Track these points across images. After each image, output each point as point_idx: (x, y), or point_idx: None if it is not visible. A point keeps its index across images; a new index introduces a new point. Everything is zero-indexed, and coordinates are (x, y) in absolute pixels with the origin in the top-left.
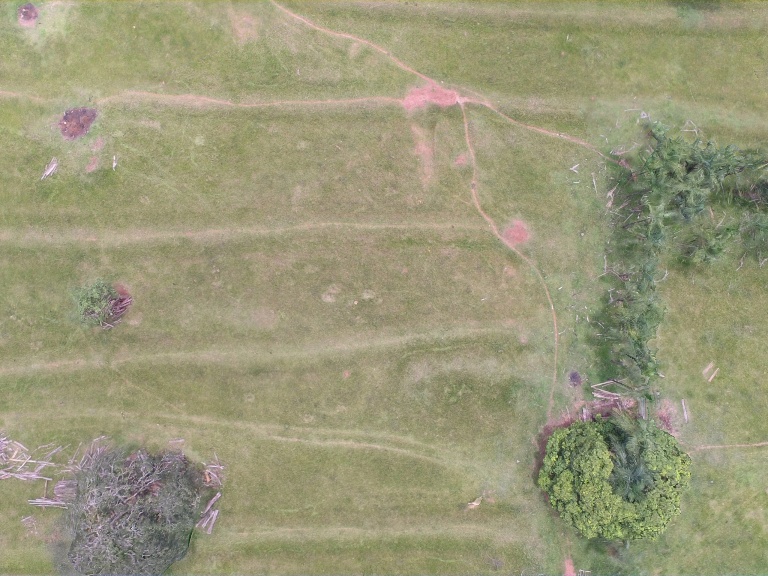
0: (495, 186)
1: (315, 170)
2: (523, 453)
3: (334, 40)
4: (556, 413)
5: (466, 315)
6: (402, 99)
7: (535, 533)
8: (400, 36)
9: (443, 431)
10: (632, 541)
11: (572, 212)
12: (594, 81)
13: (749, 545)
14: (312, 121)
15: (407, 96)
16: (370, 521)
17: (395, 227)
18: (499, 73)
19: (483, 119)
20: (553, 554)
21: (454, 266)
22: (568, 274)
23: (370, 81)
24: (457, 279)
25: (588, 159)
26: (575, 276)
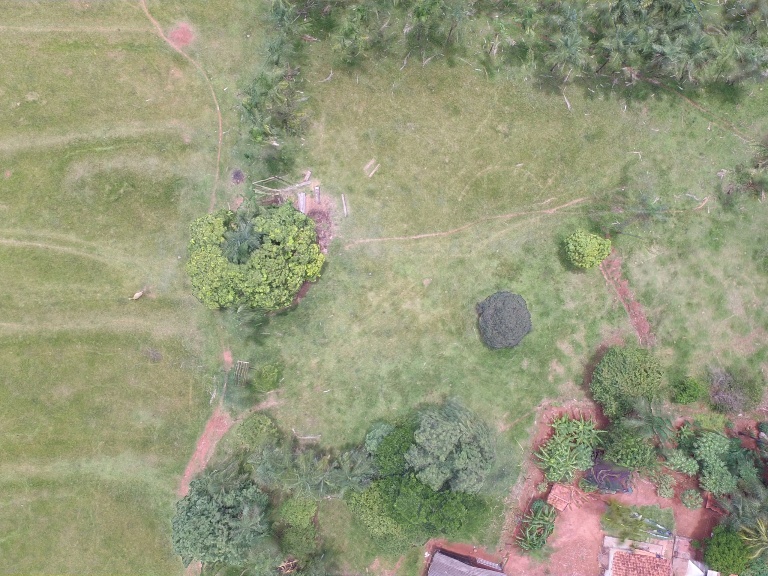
0: None
1: None
2: (184, 249)
3: None
4: (218, 210)
5: (131, 116)
6: None
7: (193, 326)
8: None
9: (104, 228)
10: (290, 332)
11: (239, 14)
12: None
13: (405, 334)
14: None
15: None
16: (29, 317)
17: (61, 30)
18: None
19: None
20: (212, 346)
21: (119, 68)
22: (232, 74)
23: None
24: (122, 81)
25: None
26: (240, 77)
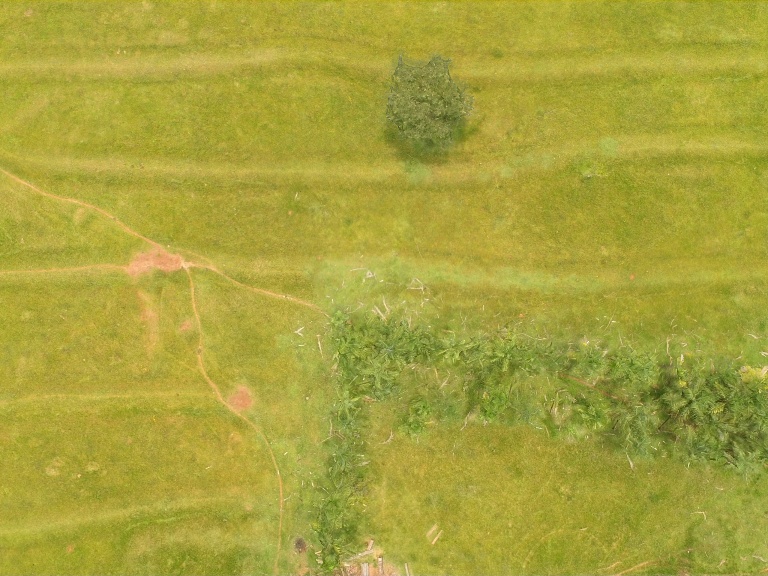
0: (220, 352)
1: (39, 341)
2: None
3: (60, 206)
4: None
5: (191, 484)
6: (126, 266)
7: None
8: (126, 200)
9: None
10: None
11: (297, 376)
12: (321, 240)
13: None
14: (37, 290)
15: (132, 262)
16: None
17: (120, 397)
18: (226, 235)
19: (209, 283)
20: None
21: (179, 435)
22: (292, 439)
23: (95, 248)
24: (182, 448)
25: (313, 321)
26: (300, 441)
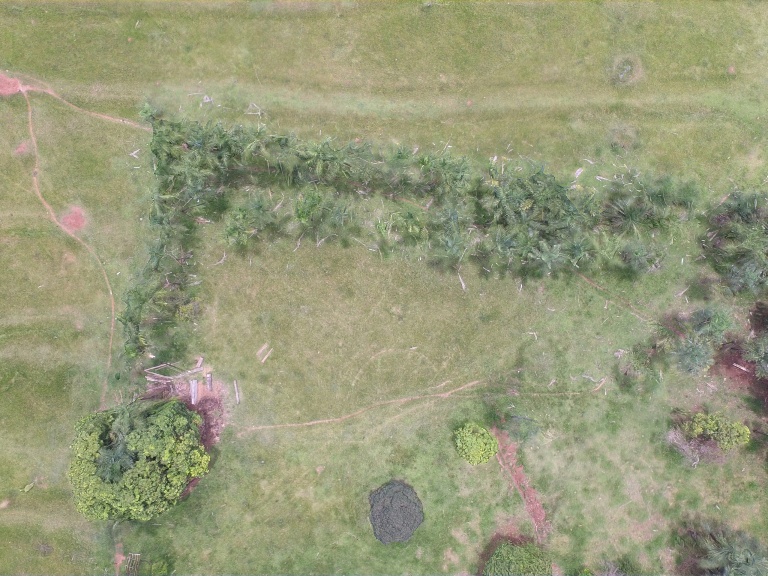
0: (55, 173)
1: None
2: None
3: None
4: (110, 398)
5: (23, 303)
6: None
7: (84, 518)
8: None
9: None
10: (182, 523)
11: (131, 197)
12: (160, 66)
13: (298, 523)
14: None
15: None
16: None
17: None
18: (65, 60)
19: (46, 107)
20: (103, 538)
21: (12, 254)
22: (125, 259)
23: None
24: (15, 267)
25: None
26: (133, 261)
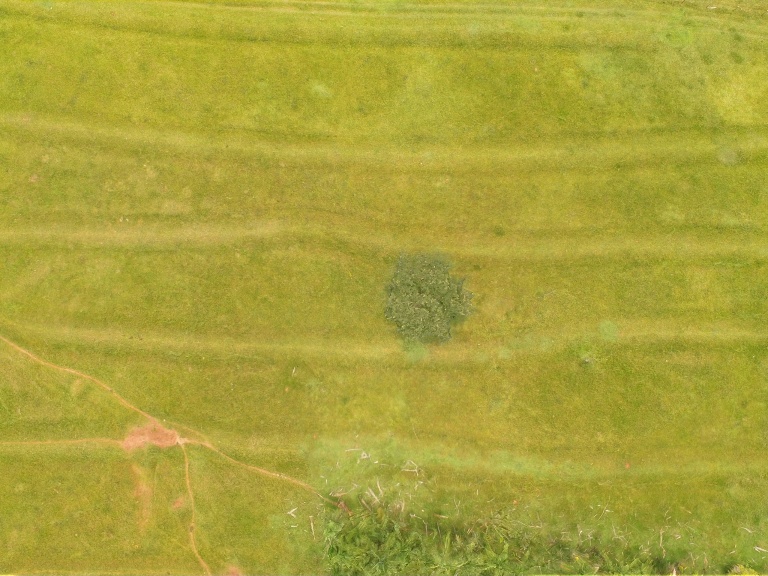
0: (212, 530)
1: (32, 514)
2: None
3: (58, 376)
4: None
5: None
6: (122, 440)
7: None
8: (124, 372)
9: None
10: None
11: (289, 557)
12: (317, 418)
13: None
14: (32, 462)
15: (127, 437)
16: None
17: (110, 574)
18: (222, 410)
19: (203, 460)
20: None
21: None
22: None
23: (91, 421)
24: None
25: (307, 502)
26: None
